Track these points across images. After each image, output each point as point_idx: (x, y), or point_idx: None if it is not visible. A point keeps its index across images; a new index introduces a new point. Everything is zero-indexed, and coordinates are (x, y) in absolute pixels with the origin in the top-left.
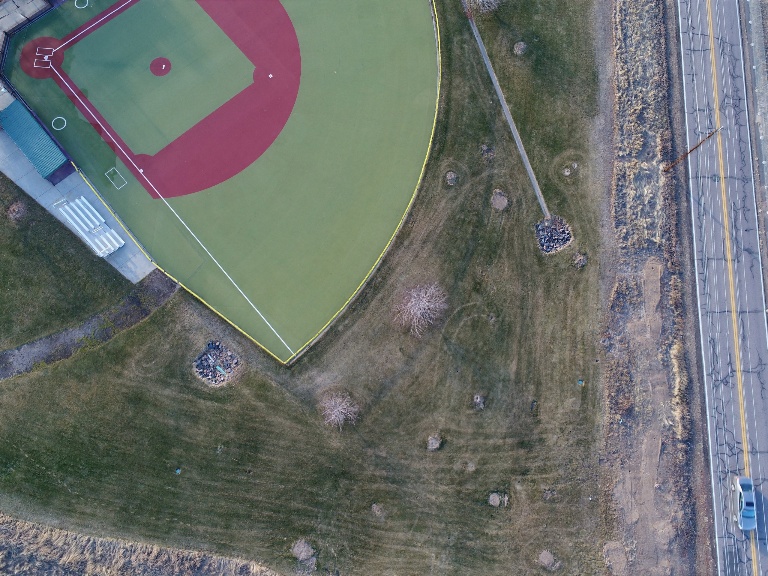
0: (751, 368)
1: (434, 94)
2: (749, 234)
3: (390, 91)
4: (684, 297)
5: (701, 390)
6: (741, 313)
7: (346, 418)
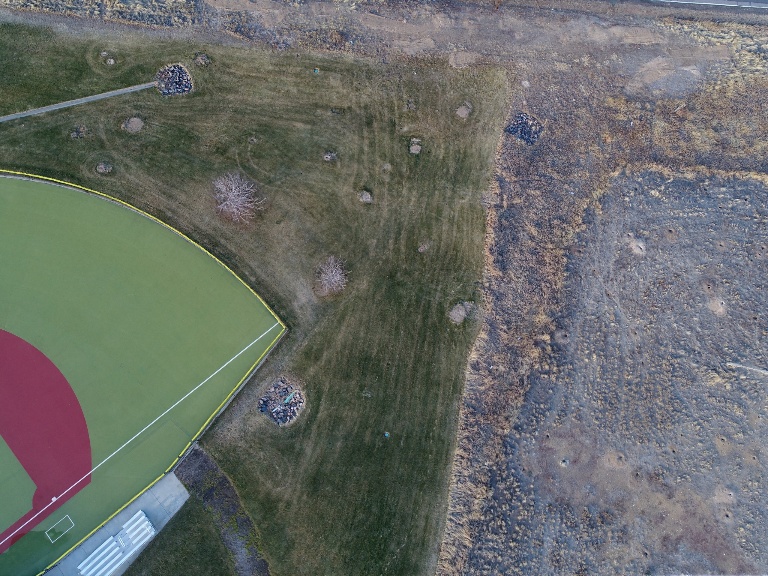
0: None
1: (4, 180)
2: None
3: None
4: None
5: None
6: None
7: None
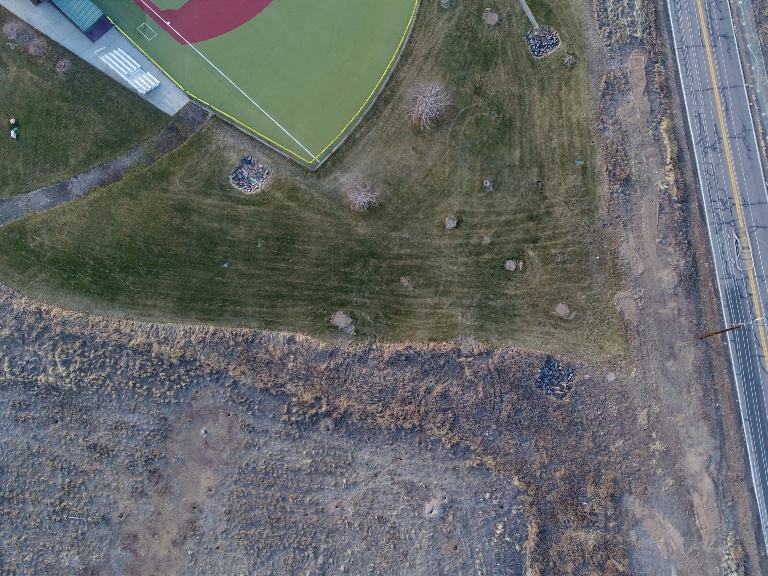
0: (736, 134)
1: None
2: (723, 22)
3: None
4: (668, 81)
5: (691, 157)
6: (722, 89)
7: (370, 203)
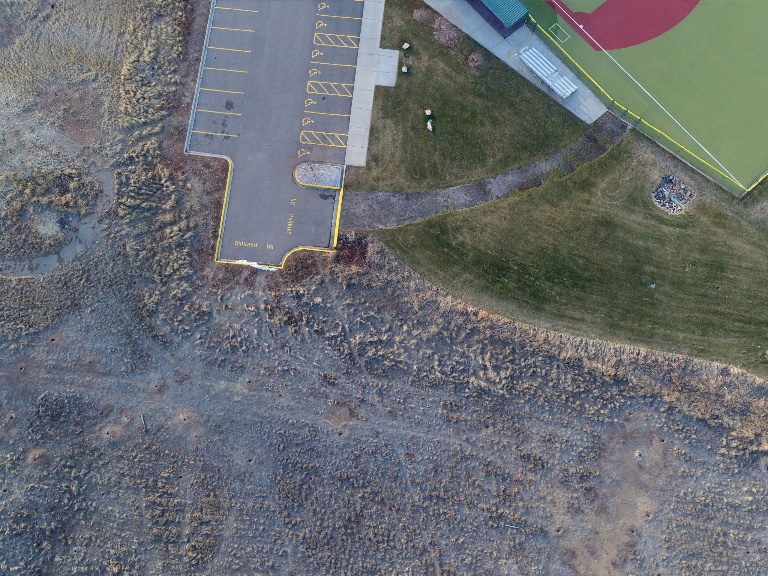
0: None
1: None
2: None
3: None
4: None
5: None
6: None
7: None
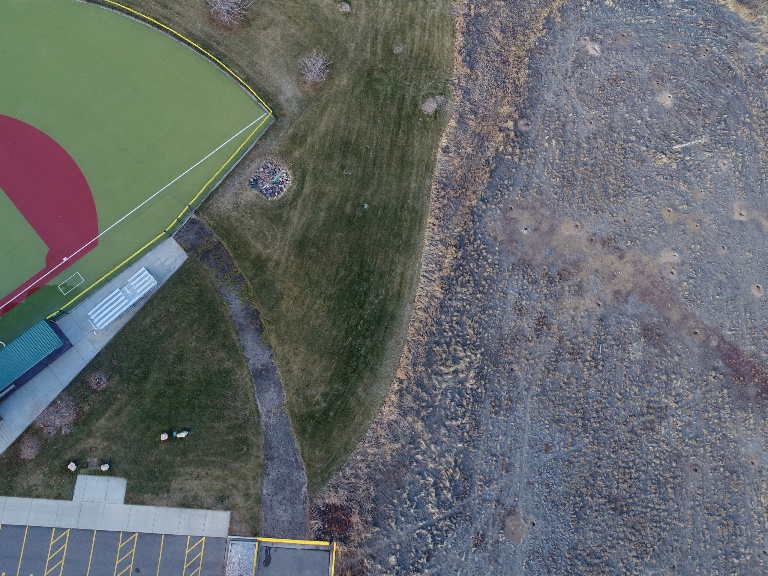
0: None
1: None
2: None
3: (3, 30)
4: None
5: None
6: None
7: None
